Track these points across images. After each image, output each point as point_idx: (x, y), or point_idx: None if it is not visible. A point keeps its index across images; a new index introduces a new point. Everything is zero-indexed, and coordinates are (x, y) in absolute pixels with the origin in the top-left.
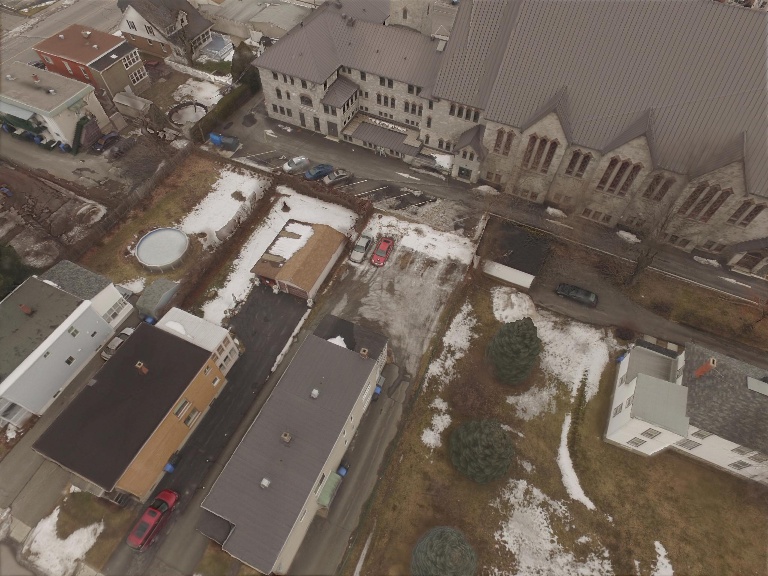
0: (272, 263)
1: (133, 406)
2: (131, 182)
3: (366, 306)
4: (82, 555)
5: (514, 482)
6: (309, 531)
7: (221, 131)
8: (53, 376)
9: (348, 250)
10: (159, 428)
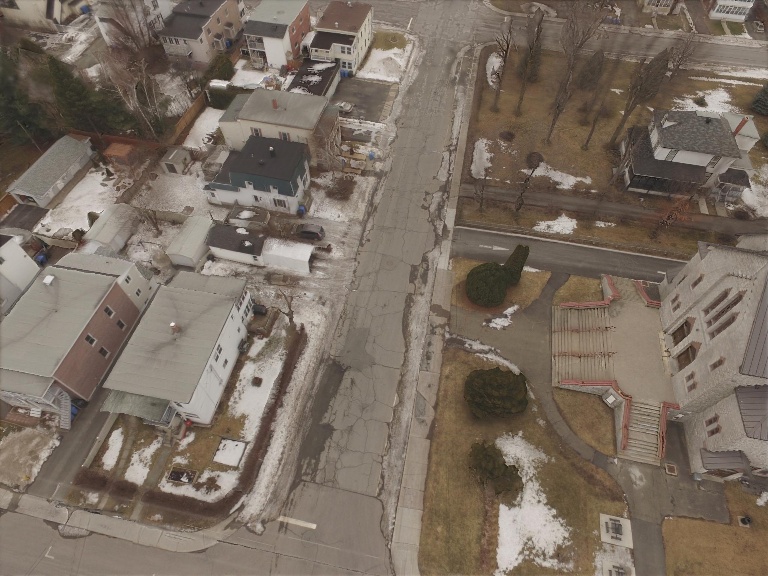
0: None
1: None
2: None
3: None
4: None
5: None
6: None
7: None
8: None
9: None
10: None
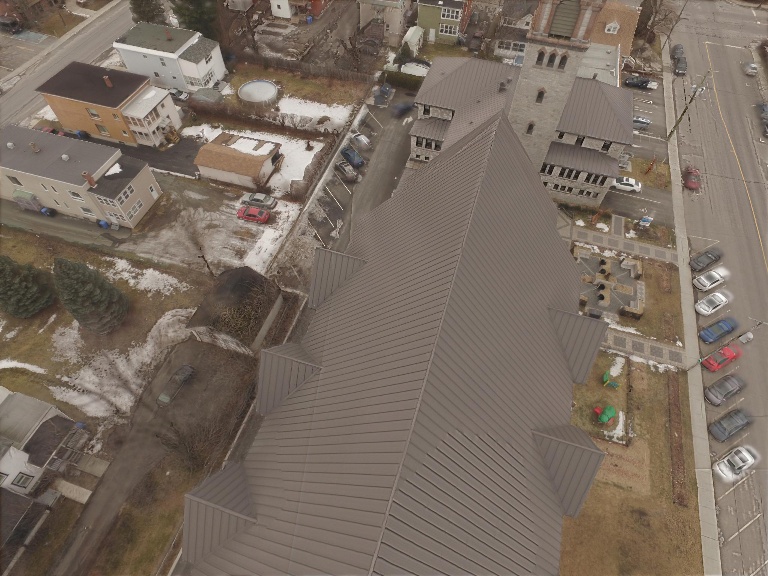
0: (227, 140)
1: (88, 88)
2: (326, 63)
3: (193, 211)
4: (45, 118)
5: (2, 324)
6: (17, 203)
7: (402, 92)
8: (146, 71)
9: (257, 192)
10: (74, 103)
